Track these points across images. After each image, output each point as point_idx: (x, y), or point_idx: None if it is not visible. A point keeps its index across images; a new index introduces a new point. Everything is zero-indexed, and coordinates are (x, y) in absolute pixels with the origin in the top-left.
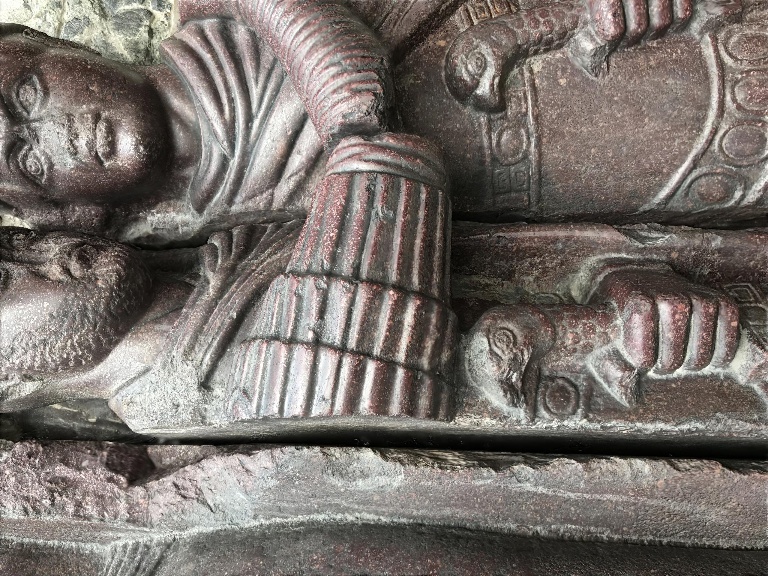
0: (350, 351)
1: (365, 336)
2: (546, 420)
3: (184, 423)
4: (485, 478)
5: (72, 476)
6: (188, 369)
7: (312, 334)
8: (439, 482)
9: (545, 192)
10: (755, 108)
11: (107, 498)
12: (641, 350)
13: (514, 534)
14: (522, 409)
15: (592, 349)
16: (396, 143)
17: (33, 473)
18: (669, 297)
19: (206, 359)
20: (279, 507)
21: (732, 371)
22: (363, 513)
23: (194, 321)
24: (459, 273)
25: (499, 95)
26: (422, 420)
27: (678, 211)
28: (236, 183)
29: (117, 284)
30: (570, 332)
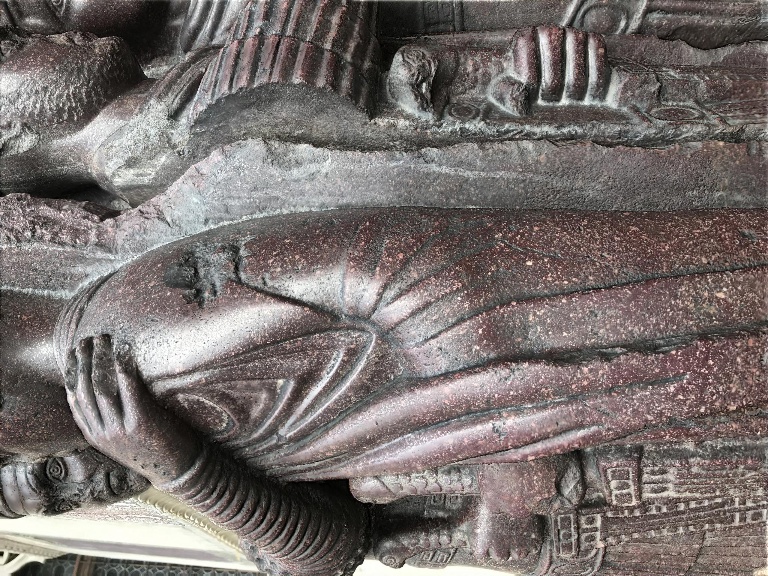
0: (288, 36)
1: (300, 27)
2: (450, 121)
3: (153, 146)
4: (398, 160)
5: (53, 216)
6: (161, 108)
7: (259, 30)
8: (360, 165)
9: (467, 24)
10: None
11: (81, 231)
12: (526, 66)
13: None
14: (431, 113)
15: (490, 78)
16: None
17: (20, 210)
18: None
19: (177, 99)
20: (226, 206)
21: (608, 103)
22: (297, 207)
23: (170, 75)
24: None
25: None
26: (346, 108)
27: None
28: (217, 16)
29: (111, 54)
30: (471, 59)
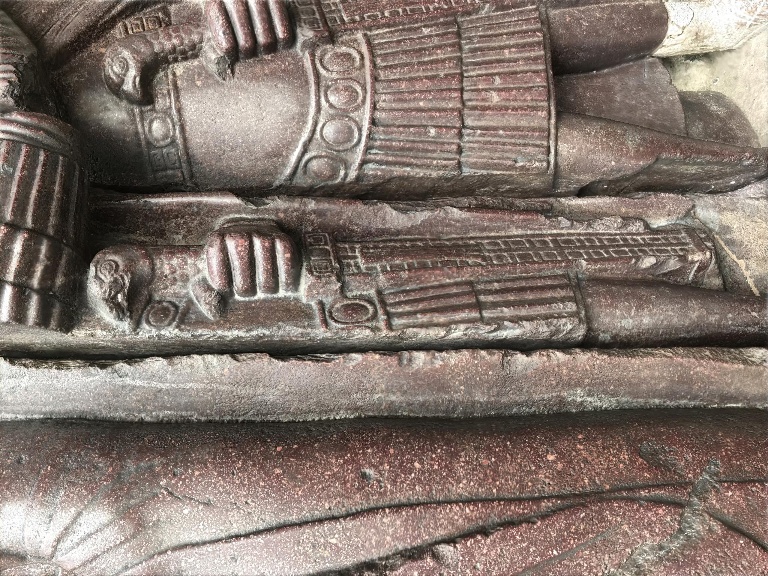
0: None
1: None
2: (146, 330)
3: None
4: (93, 375)
5: None
6: None
7: None
8: (57, 380)
9: (196, 170)
10: (343, 107)
11: None
12: (216, 275)
13: (123, 421)
14: (127, 322)
15: (188, 278)
16: (23, 118)
17: None
18: (233, 234)
19: None
20: None
21: (300, 294)
22: (3, 413)
23: None
24: (117, 232)
25: (141, 91)
26: (38, 330)
27: (302, 186)
28: None
29: None
30: (167, 264)
